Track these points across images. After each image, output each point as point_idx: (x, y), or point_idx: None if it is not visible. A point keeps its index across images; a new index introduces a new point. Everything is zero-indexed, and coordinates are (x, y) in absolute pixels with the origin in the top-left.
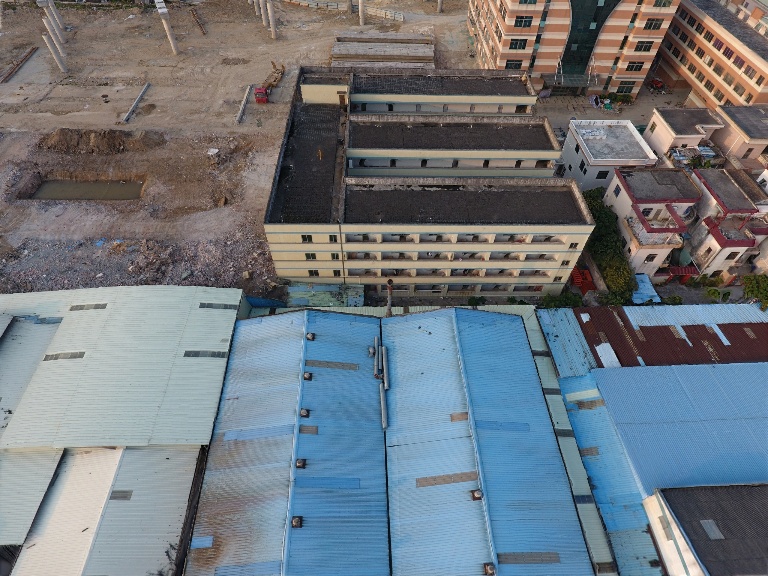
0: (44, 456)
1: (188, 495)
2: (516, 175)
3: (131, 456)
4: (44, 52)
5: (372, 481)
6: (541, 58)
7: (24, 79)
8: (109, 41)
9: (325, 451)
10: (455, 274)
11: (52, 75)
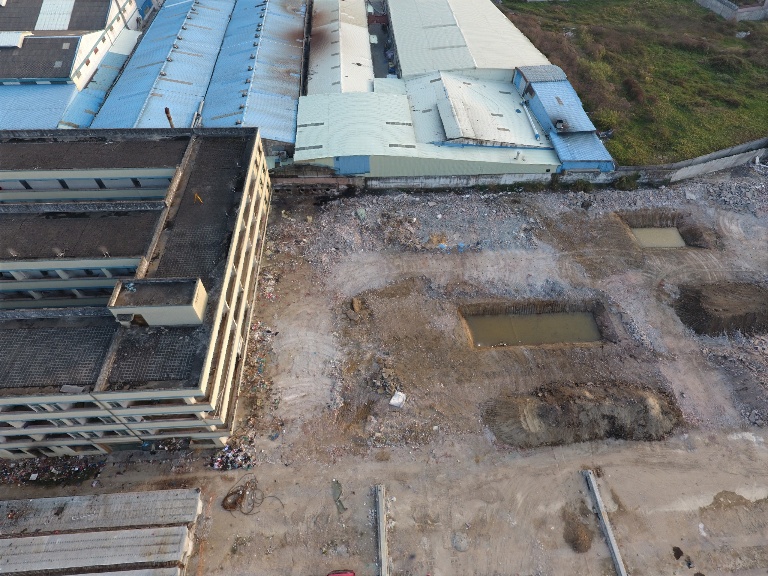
0: None
1: None
2: None
3: None
4: None
5: None
6: None
7: None
8: None
9: (236, 87)
10: None
11: None
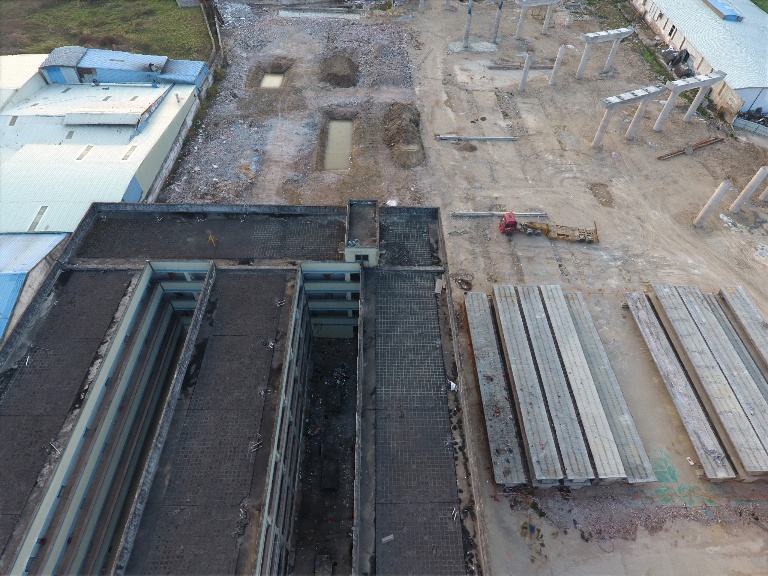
0: None
1: None
2: None
3: None
4: None
5: None
6: None
7: (498, 75)
8: (596, 100)
9: None
10: None
11: (511, 85)
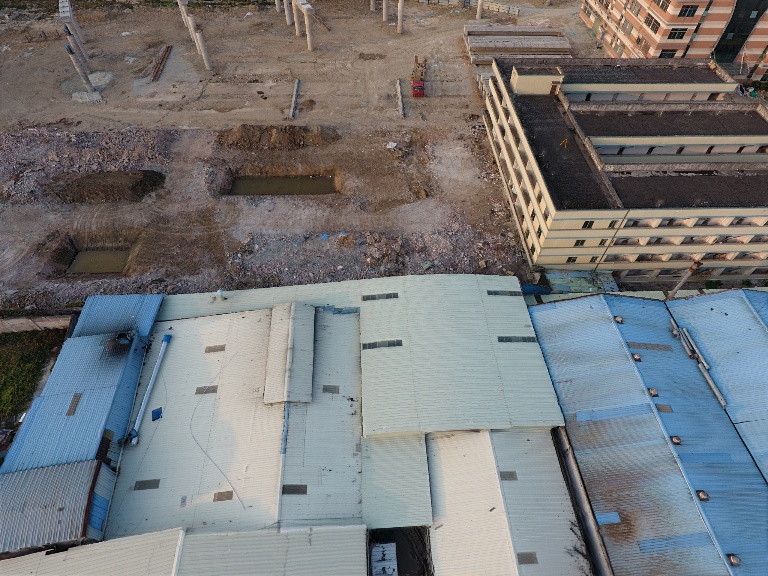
0: (410, 441)
1: (561, 475)
2: (740, 160)
3: (499, 438)
4: (180, 50)
5: (740, 456)
6: (694, 47)
7: (173, 77)
8: (239, 38)
9: (689, 428)
10: (703, 258)
11: (199, 73)
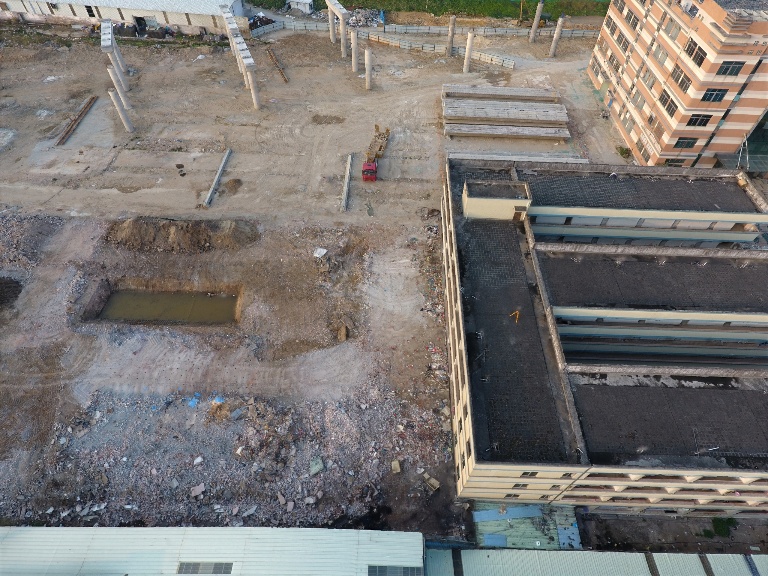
0: None
1: None
2: None
3: None
4: (105, 103)
5: None
6: (721, 136)
7: (84, 140)
8: (178, 89)
9: None
10: None
11: (116, 135)
